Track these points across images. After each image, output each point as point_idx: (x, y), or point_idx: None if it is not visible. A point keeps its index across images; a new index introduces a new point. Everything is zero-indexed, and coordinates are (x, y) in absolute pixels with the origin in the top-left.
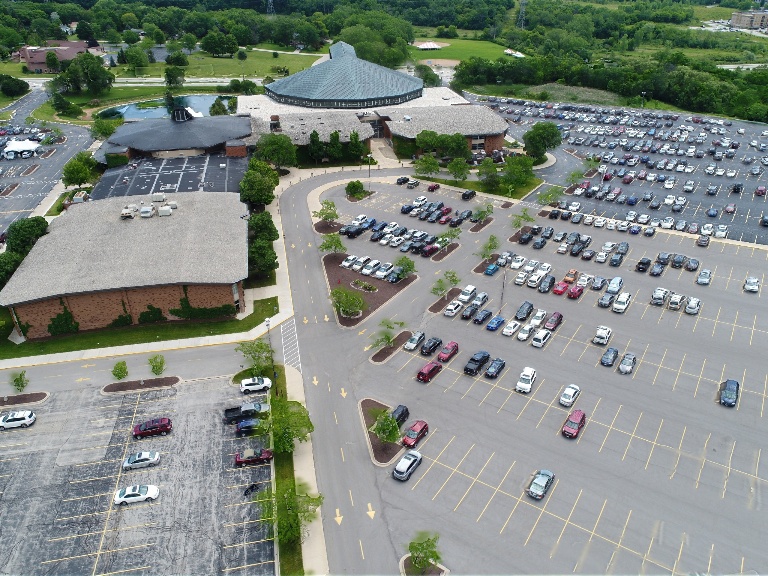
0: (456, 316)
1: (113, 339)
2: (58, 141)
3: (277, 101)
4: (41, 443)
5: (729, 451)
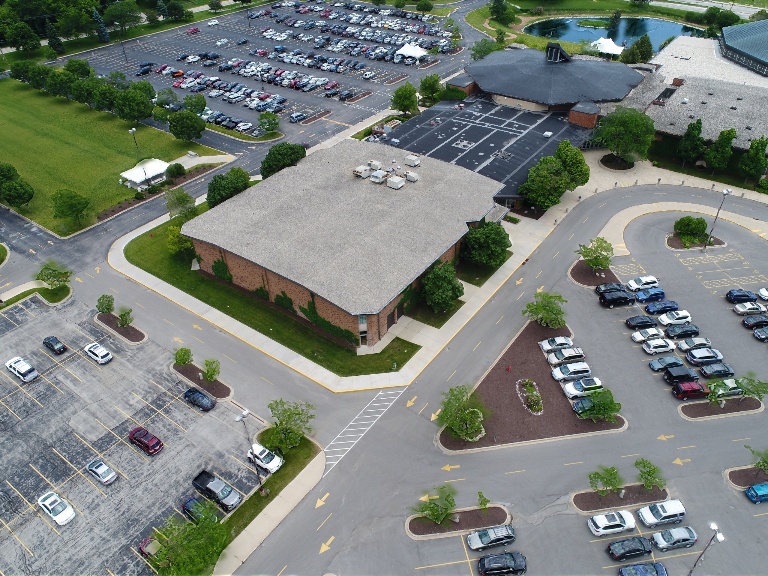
0: (603, 538)
1: (241, 309)
2: (451, 52)
3: (722, 53)
4: (87, 389)
5: None
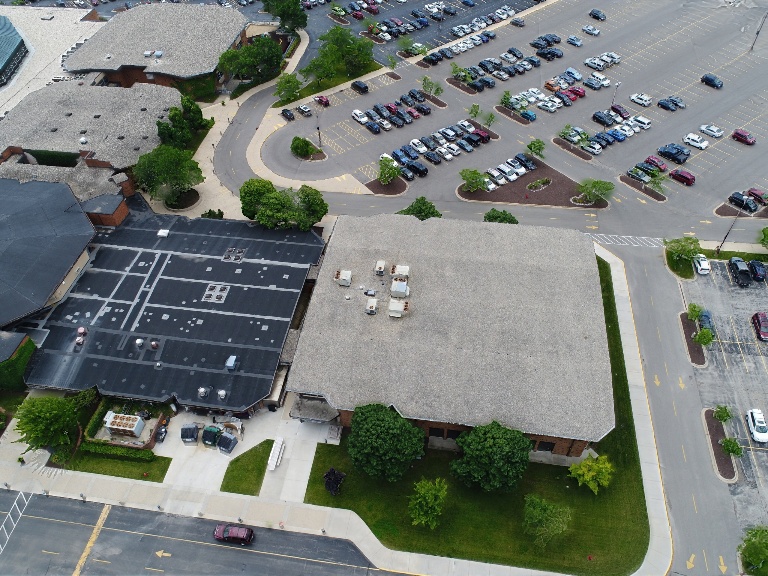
0: None
1: None
2: None
3: None
4: None
5: (765, 99)
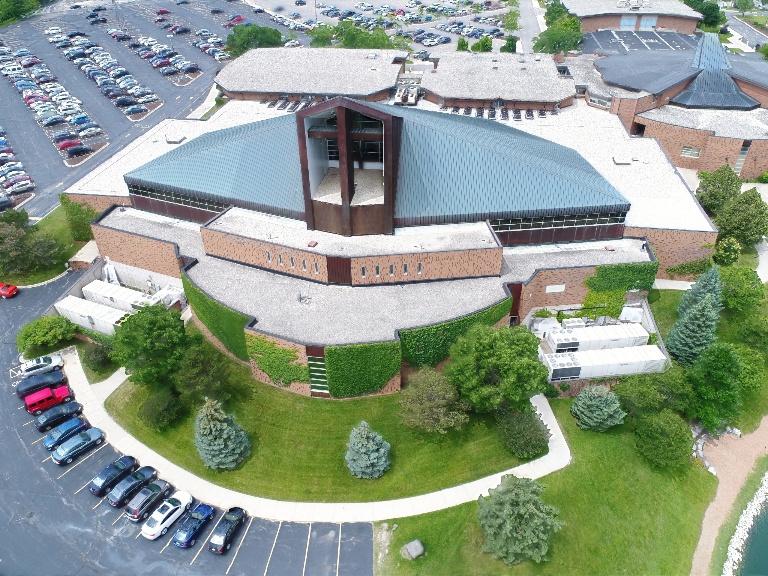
0: None
1: None
2: None
3: None
4: None
5: None
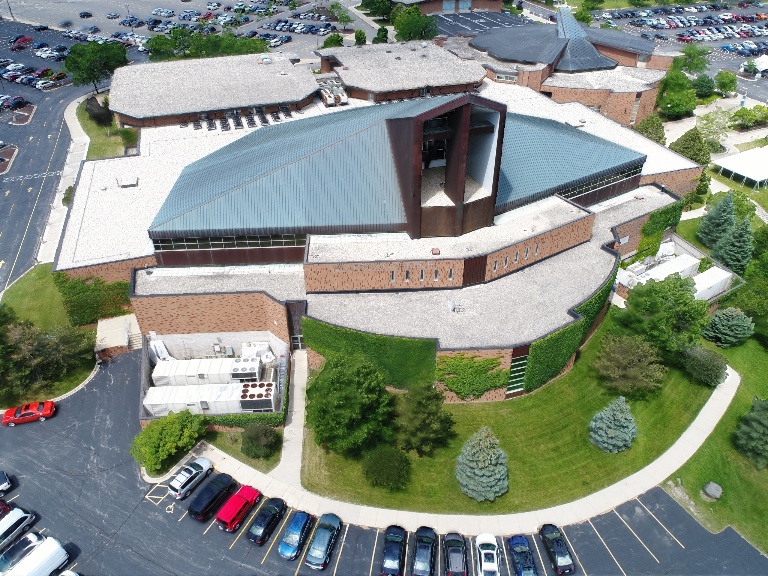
0: None
1: None
2: None
3: None
4: None
5: None
